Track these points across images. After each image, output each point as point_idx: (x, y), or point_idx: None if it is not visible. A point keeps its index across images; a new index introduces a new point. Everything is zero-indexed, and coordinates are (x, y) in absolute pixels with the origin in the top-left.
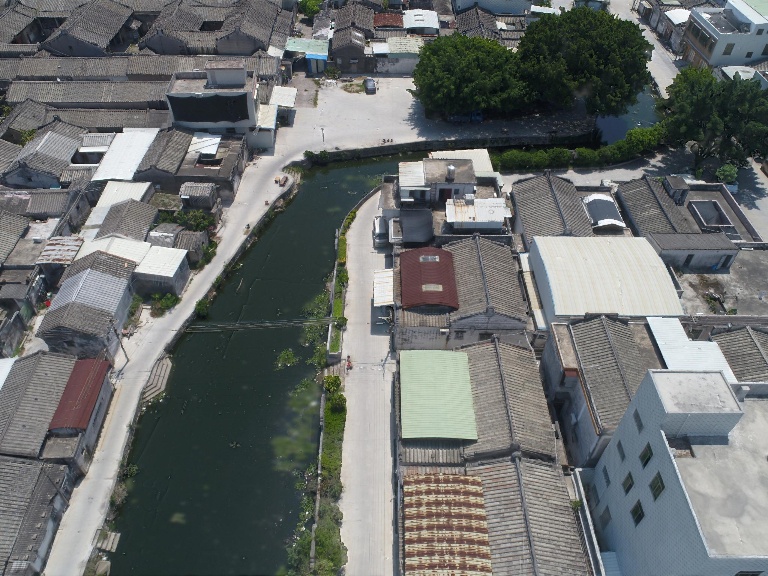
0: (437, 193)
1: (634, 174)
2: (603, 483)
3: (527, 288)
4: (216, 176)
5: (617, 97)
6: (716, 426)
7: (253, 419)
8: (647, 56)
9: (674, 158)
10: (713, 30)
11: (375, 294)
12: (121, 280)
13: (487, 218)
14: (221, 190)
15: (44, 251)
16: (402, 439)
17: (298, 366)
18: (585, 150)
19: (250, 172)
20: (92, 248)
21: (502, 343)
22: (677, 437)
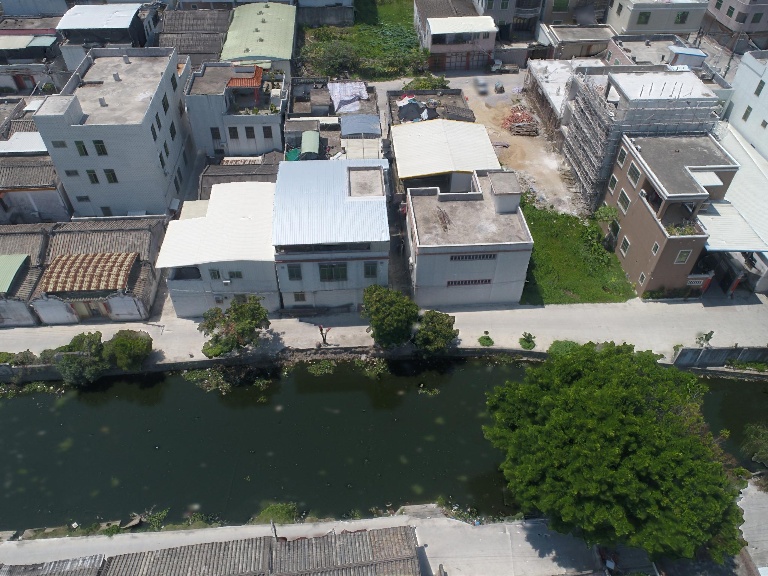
0: None
1: None
2: (86, 205)
3: None
4: None
5: None
6: (78, 111)
7: None
8: None
9: None
10: None
11: None
12: None
13: None
14: None
15: None
16: (7, 295)
17: None
18: None
19: None
20: None
21: None
22: None
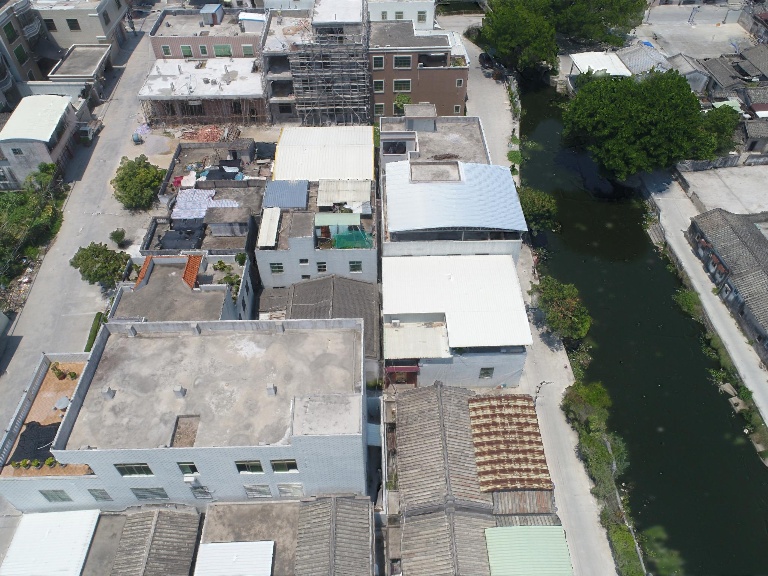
0: None
1: None
2: None
3: None
4: None
5: None
6: None
7: None
8: None
9: None
10: None
11: None
12: None
13: None
14: None
15: None
16: None
17: None
18: None
19: None
20: None
21: None
22: None
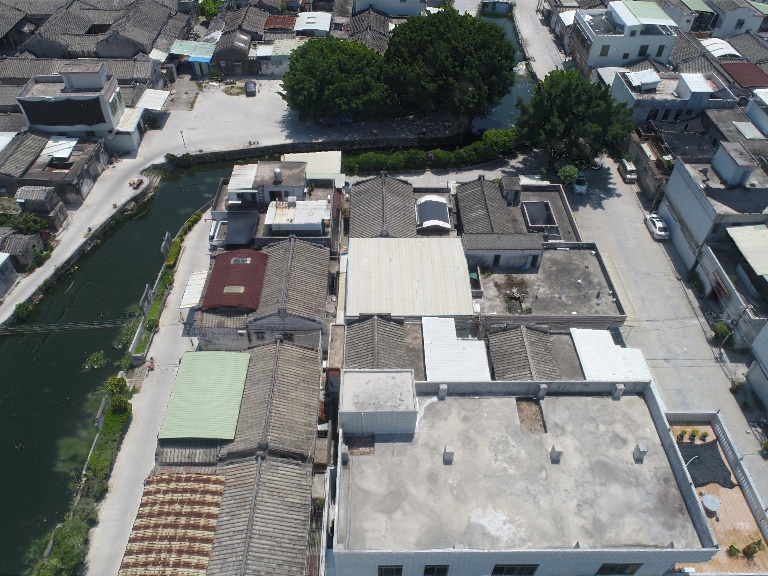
0: (267, 195)
1: (490, 175)
2: None
3: (339, 289)
4: (59, 179)
5: (475, 99)
6: (398, 424)
7: (45, 421)
8: (511, 58)
9: (535, 159)
10: (589, 32)
11: (184, 296)
12: None
13: (304, 220)
14: (68, 193)
15: None
16: (160, 439)
17: (105, 368)
18: (440, 151)
19: (107, 175)
20: None
21: (286, 344)
22: (366, 435)
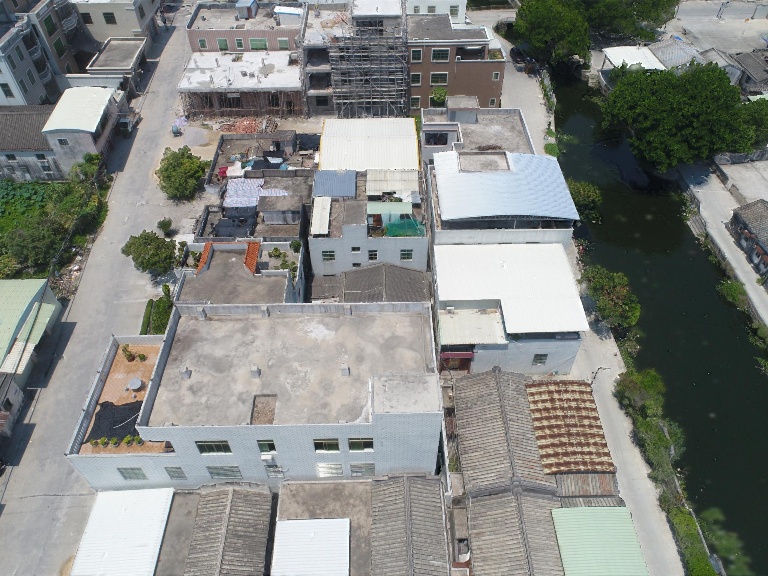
0: None
1: None
2: None
3: None
4: None
5: None
6: None
7: None
8: None
9: None
10: None
11: None
12: None
13: None
14: None
15: None
16: None
17: None
18: None
19: None
20: None
21: None
22: None
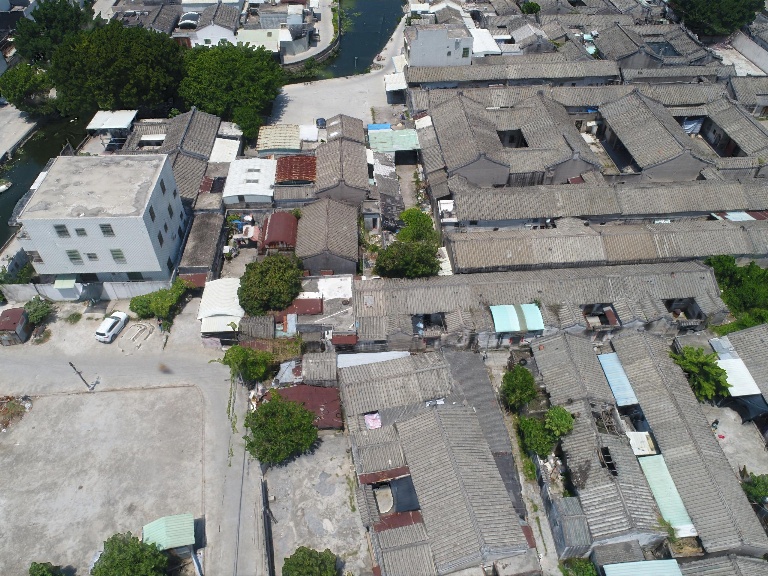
0: None
1: None
2: None
3: None
4: None
5: None
6: None
7: None
8: None
9: None
10: None
11: (318, 2)
12: (432, 0)
13: None
14: None
15: (478, 6)
16: None
17: None
18: None
19: None
20: (456, 7)
21: None
22: None
